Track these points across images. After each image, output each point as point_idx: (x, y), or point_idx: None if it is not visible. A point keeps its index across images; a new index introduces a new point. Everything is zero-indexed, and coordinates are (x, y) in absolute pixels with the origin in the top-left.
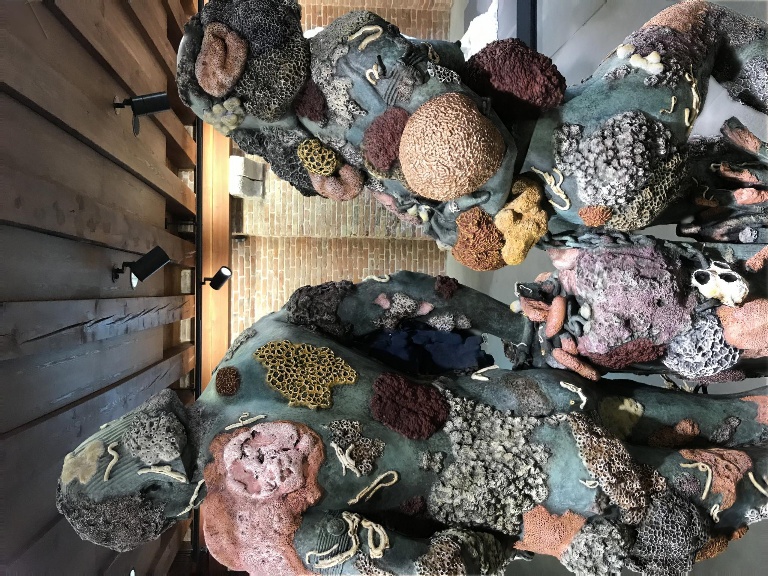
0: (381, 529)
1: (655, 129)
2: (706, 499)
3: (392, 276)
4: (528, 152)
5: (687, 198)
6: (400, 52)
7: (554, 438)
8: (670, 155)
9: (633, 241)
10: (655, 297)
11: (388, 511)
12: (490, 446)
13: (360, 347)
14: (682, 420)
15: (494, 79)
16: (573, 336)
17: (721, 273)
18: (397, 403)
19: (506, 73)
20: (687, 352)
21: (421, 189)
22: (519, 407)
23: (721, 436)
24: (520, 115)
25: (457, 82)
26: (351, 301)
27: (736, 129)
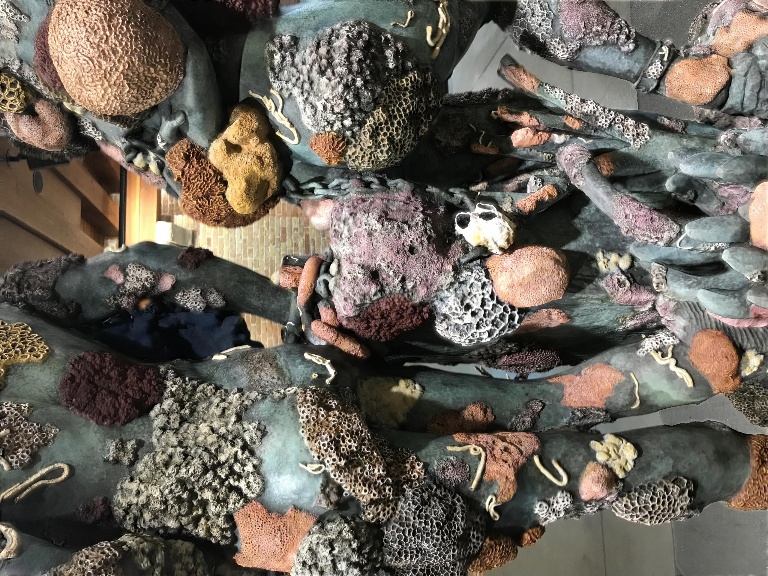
0: (11, 534)
1: (381, 40)
2: (478, 489)
3: (130, 246)
4: (241, 72)
5: (466, 147)
6: None
7: (273, 413)
8: (405, 72)
9: (390, 186)
10: (405, 242)
11: (57, 518)
12: (198, 429)
13: (87, 330)
14: (471, 403)
15: None
16: (332, 303)
17: (481, 212)
18: (96, 384)
19: None
20: (453, 311)
21: (78, 97)
22: (249, 384)
23: (522, 423)
24: (227, 28)
25: None
26: (74, 274)
27: (509, 67)
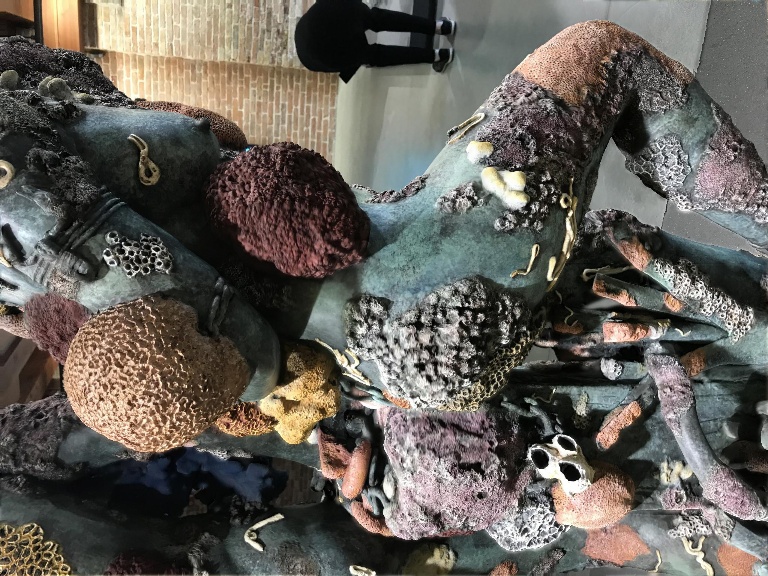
0: None
1: (498, 310)
2: None
3: None
4: (309, 323)
5: None
6: (48, 220)
7: None
8: (516, 336)
9: None
10: (475, 490)
11: None
12: None
13: (98, 489)
14: (499, 564)
15: (244, 238)
16: None
17: (563, 462)
18: None
19: (262, 234)
20: (509, 535)
21: None
22: None
23: (541, 570)
24: None
25: (164, 270)
26: (79, 438)
27: (622, 241)
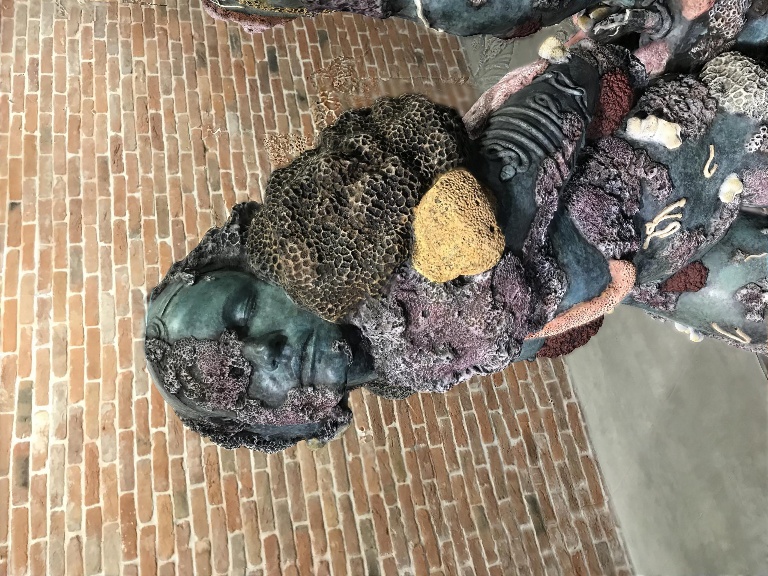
0: None
1: None
2: None
3: None
4: None
5: None
6: None
7: None
8: None
9: None
10: None
11: None
12: None
13: None
14: None
15: None
16: None
17: None
18: None
19: None
20: None
21: None
22: None
23: None
24: None
25: None
26: None
27: None
